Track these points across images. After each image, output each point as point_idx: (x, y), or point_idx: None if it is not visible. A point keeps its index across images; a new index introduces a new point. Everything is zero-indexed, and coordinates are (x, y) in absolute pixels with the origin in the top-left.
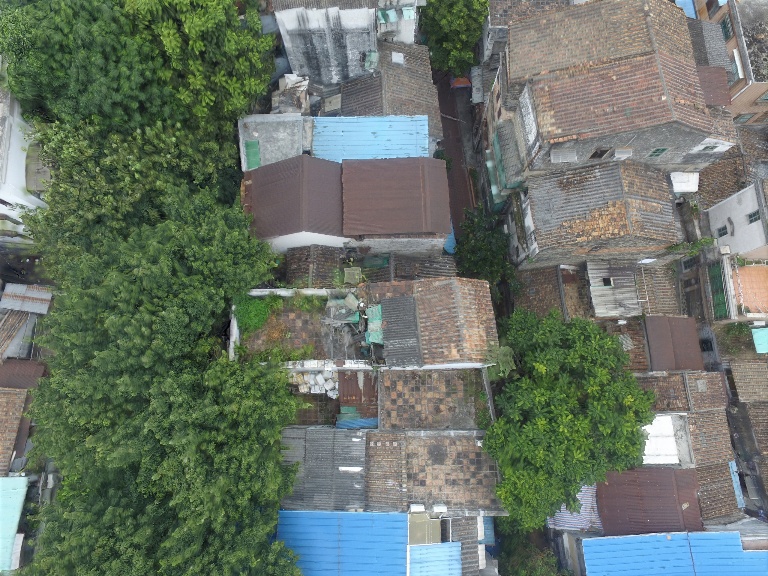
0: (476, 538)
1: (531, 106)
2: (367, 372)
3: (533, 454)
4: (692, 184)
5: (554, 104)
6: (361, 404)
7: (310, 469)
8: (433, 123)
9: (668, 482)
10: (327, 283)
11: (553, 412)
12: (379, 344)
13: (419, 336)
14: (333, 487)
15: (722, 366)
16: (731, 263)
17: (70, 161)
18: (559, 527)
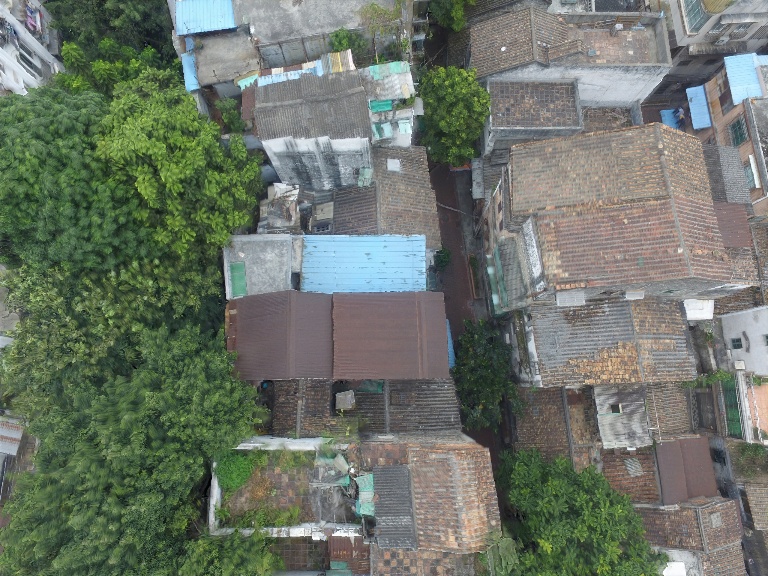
0: None
1: (535, 243)
2: None
3: None
4: (707, 311)
5: (560, 244)
6: (352, 559)
7: None
8: (431, 233)
9: None
10: (317, 419)
11: None
12: (371, 516)
13: (414, 514)
14: None
15: None
16: (746, 380)
17: (39, 306)
18: None
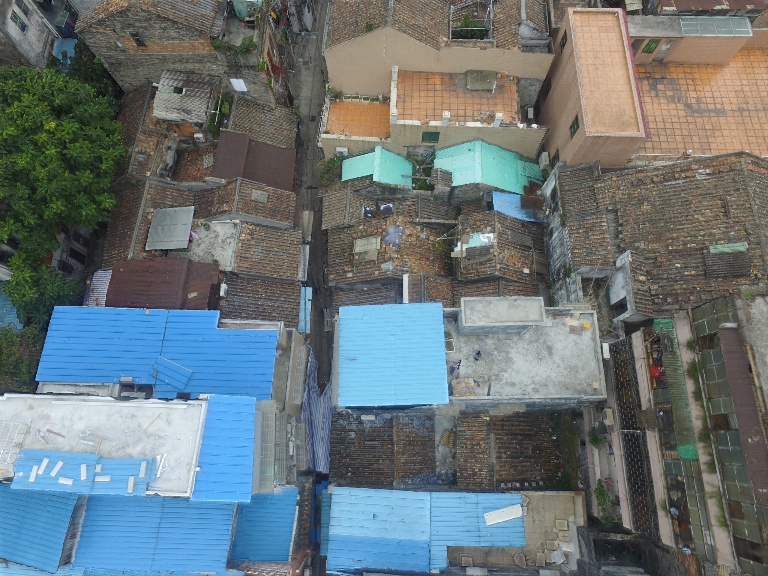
0: None
1: None
2: None
3: None
4: None
5: None
6: None
7: None
8: None
9: (178, 269)
10: None
11: None
12: None
13: None
14: None
15: None
16: (330, 97)
17: None
18: None
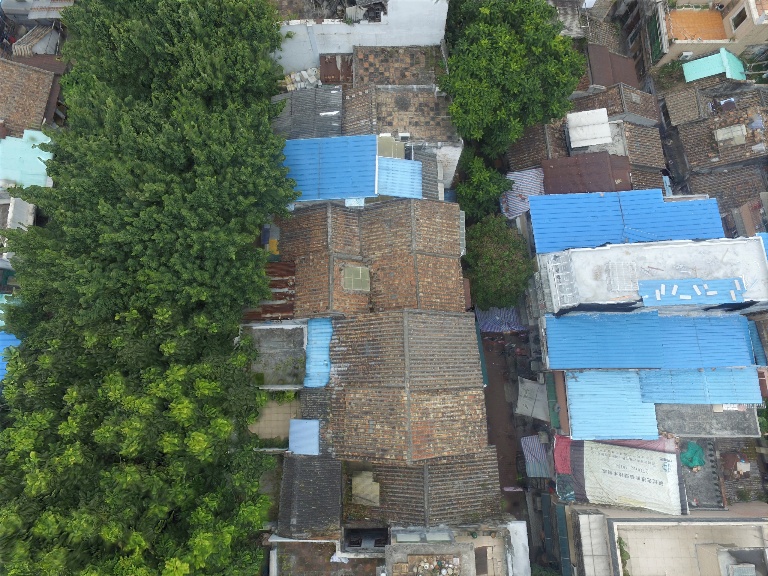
0: (436, 175)
1: None
2: (344, 56)
3: (477, 65)
4: None
5: None
6: (339, 82)
7: (296, 118)
8: None
9: (603, 161)
10: None
11: (495, 39)
12: None
13: None
14: (315, 128)
15: (659, 105)
16: (664, 8)
17: None
18: (513, 216)
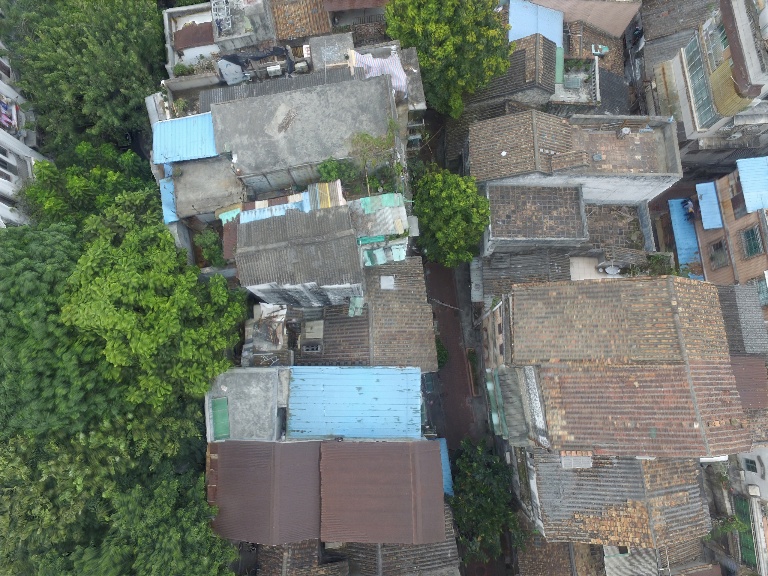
0: None
1: (539, 397)
2: None
3: None
4: None
5: (565, 402)
6: None
7: None
8: (427, 353)
9: None
10: (304, 572)
11: None
12: None
13: None
14: None
15: None
16: (761, 509)
17: None
18: None
